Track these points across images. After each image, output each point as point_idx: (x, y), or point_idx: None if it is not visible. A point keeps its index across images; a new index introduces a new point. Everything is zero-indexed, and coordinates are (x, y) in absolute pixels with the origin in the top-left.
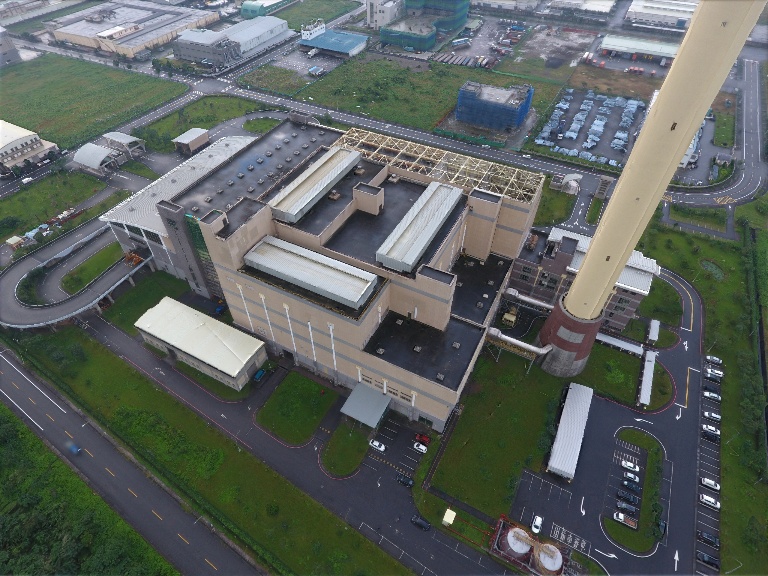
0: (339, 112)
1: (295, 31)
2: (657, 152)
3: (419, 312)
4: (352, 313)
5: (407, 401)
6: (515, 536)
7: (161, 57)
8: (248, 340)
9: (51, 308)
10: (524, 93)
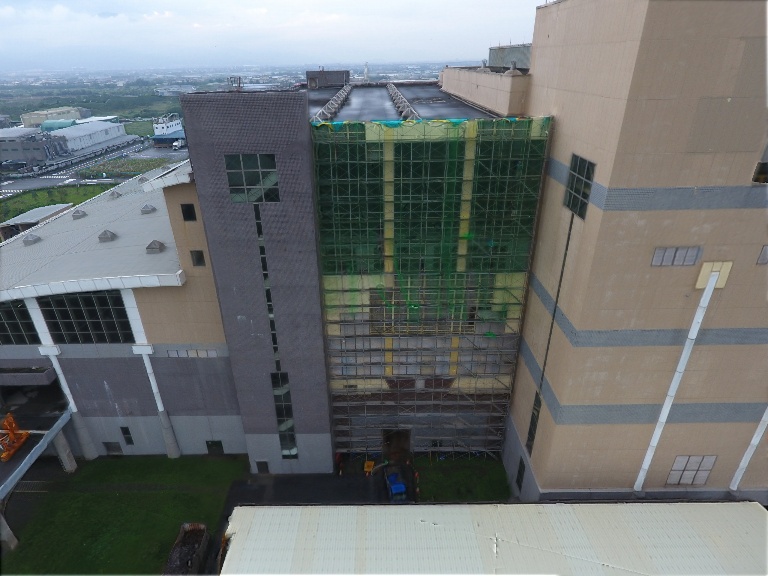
0: None
1: None
2: None
3: None
4: None
5: None
6: None
7: None
8: (713, 520)
9: None
10: None
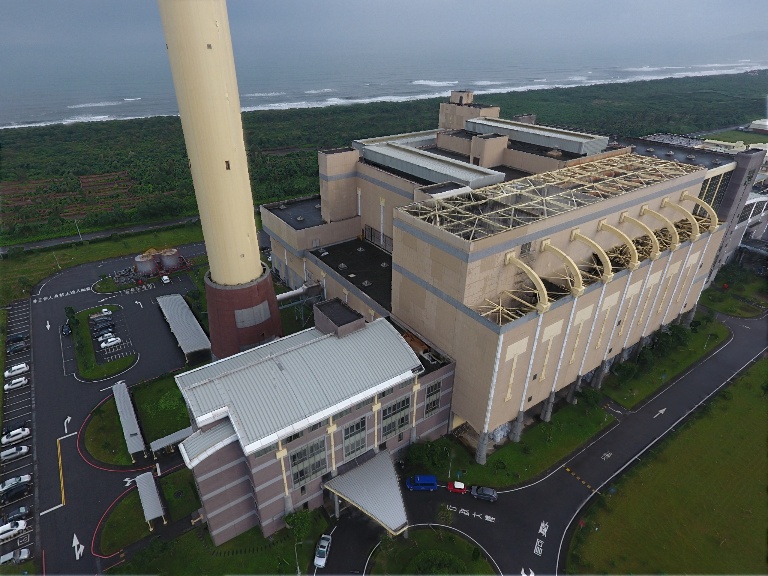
0: None
1: None
2: None
3: None
4: None
5: None
6: None
7: None
8: None
9: None
10: None
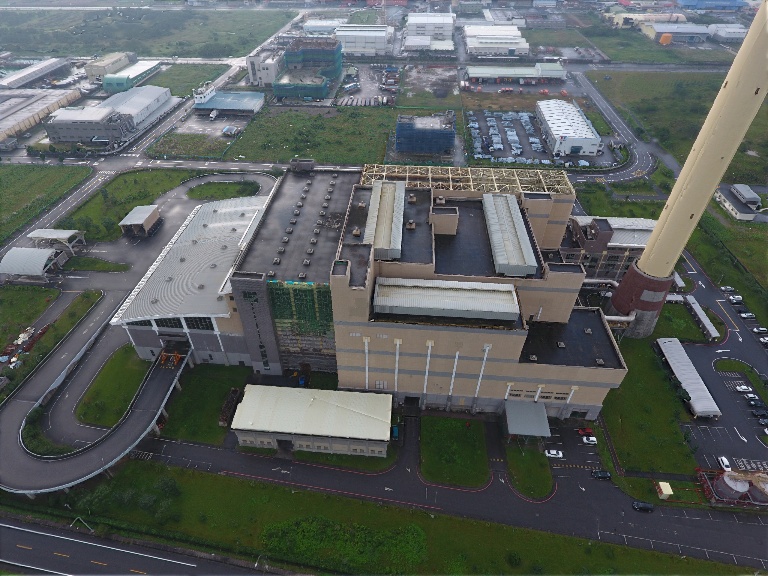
0: (281, 164)
1: (179, 97)
2: (742, 115)
3: (543, 311)
4: (512, 326)
5: (561, 400)
6: (732, 478)
7: (32, 143)
8: (374, 398)
9: (95, 449)
10: (452, 117)
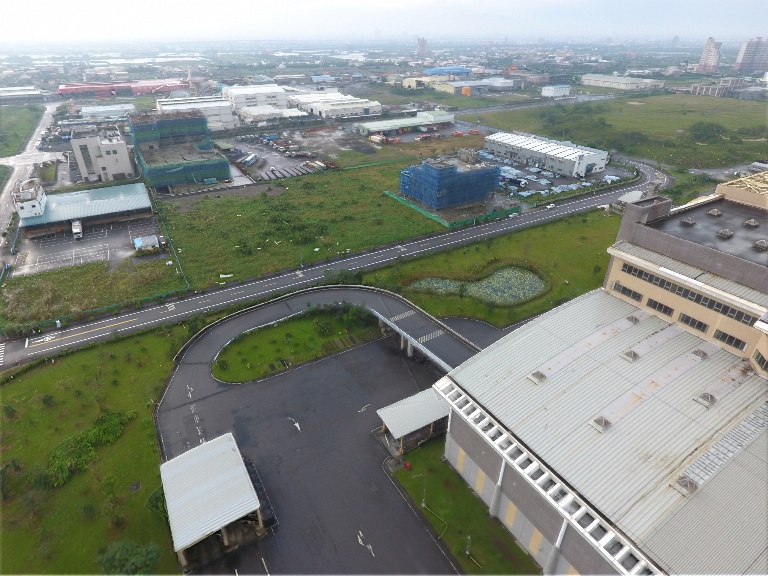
0: (311, 267)
1: None
2: None
3: None
4: None
5: None
6: None
7: None
8: None
9: None
10: None
